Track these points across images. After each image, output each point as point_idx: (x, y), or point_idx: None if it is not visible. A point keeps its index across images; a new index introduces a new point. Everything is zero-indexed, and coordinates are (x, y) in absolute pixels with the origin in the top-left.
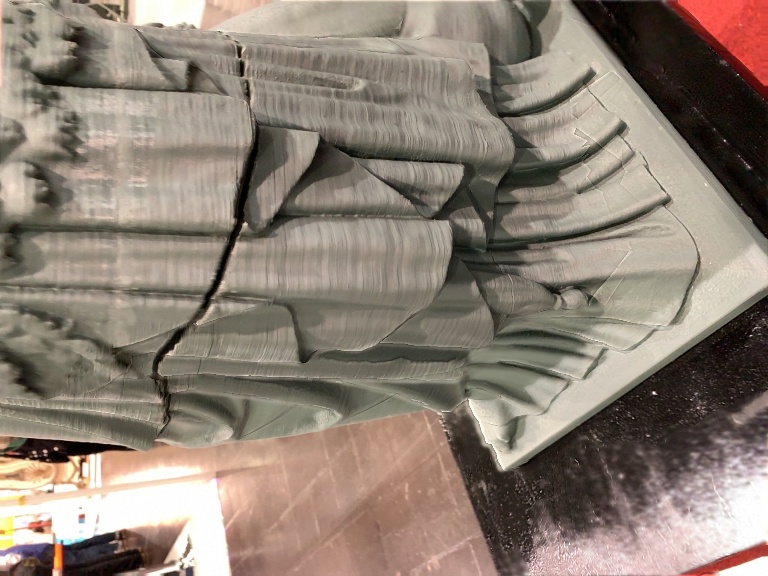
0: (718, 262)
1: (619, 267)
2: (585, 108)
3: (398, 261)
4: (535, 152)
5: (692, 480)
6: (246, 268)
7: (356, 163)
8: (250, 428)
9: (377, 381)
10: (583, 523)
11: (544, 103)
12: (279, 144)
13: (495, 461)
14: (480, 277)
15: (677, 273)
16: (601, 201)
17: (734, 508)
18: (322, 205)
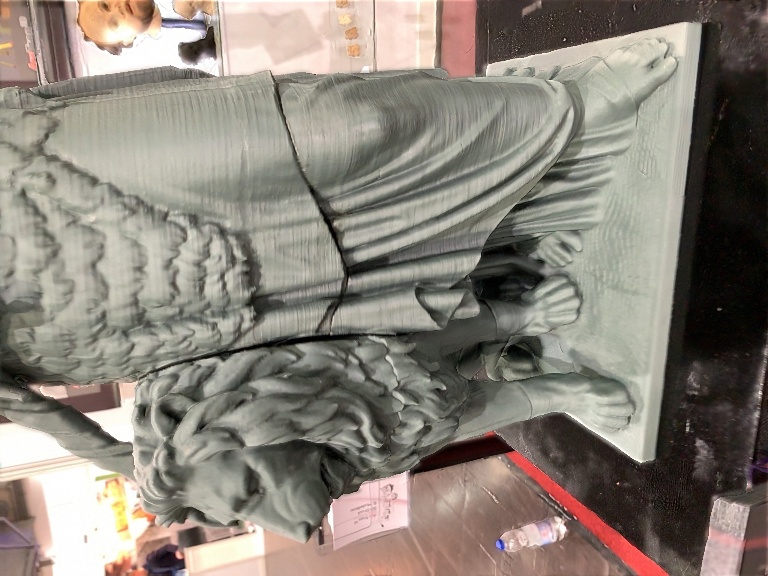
0: None
1: None
2: None
3: None
4: None
5: None
6: None
7: None
8: None
9: None
10: None
11: None
12: None
13: (722, 41)
14: None
15: None
16: None
17: None
18: None
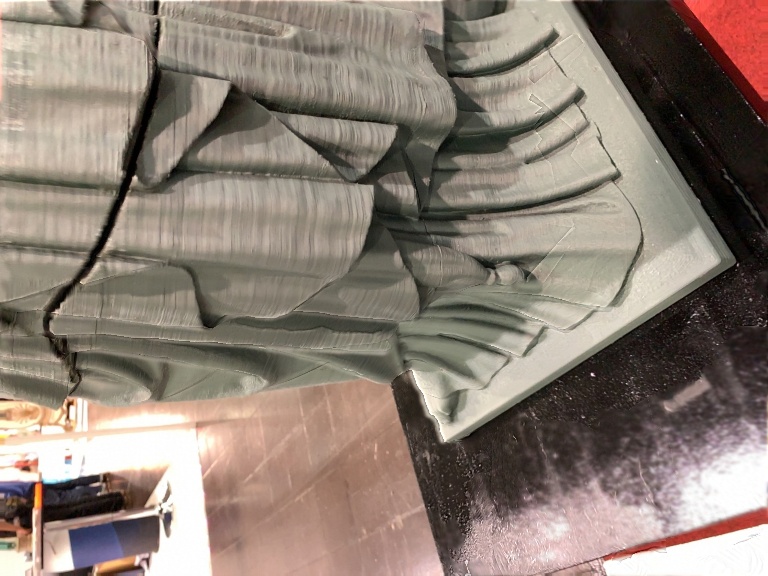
0: (660, 244)
1: (559, 244)
2: (543, 72)
3: (311, 226)
4: (484, 117)
5: (621, 464)
6: (137, 225)
7: (273, 117)
8: (171, 390)
9: (303, 349)
10: (516, 499)
11: (501, 64)
12: (182, 92)
13: (439, 432)
14: (406, 247)
15: (618, 253)
16: (548, 173)
17: (657, 495)
18: (229, 161)
